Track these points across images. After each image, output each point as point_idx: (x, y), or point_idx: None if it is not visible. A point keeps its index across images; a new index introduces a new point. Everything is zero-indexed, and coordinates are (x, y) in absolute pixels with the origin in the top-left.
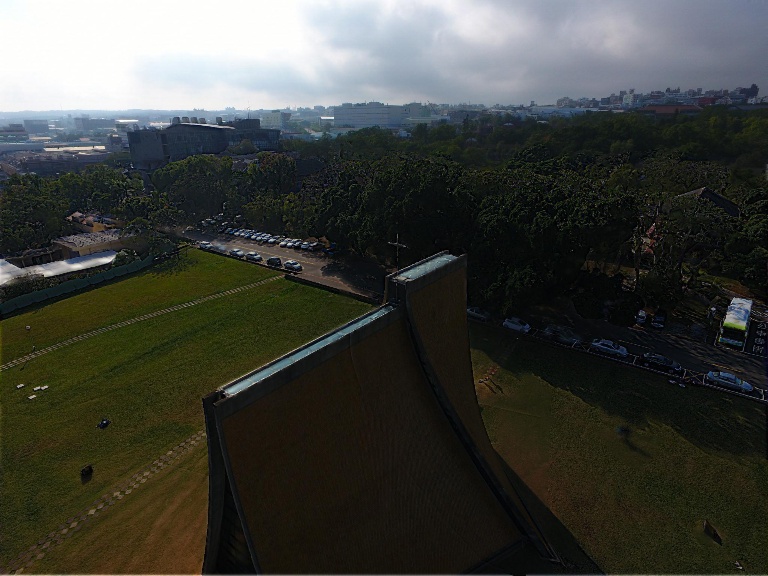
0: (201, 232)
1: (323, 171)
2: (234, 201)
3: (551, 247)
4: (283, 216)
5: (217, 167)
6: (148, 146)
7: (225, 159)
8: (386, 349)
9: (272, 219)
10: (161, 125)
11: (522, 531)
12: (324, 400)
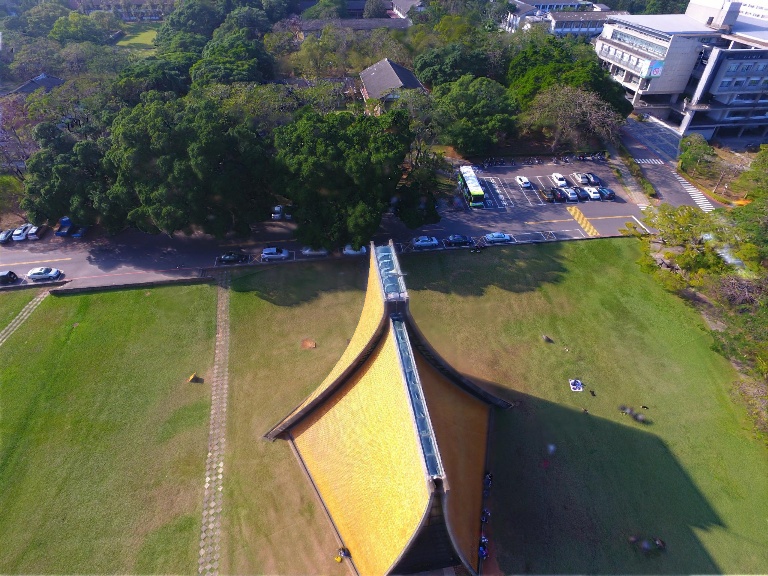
0: None
1: None
2: None
3: (371, 179)
4: None
5: None
6: None
7: None
8: None
9: None
10: None
11: (489, 403)
12: None
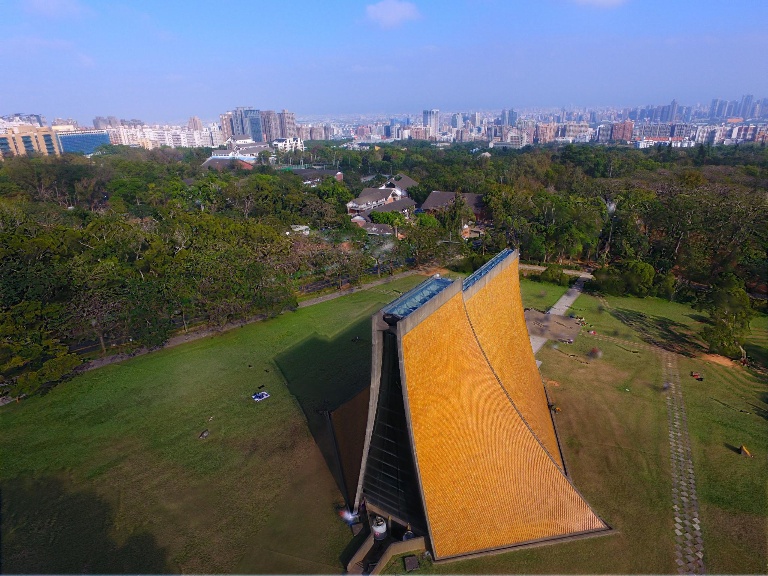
0: None
1: None
2: None
3: None
4: None
5: None
6: None
7: None
8: None
9: None
10: None
11: None
12: None
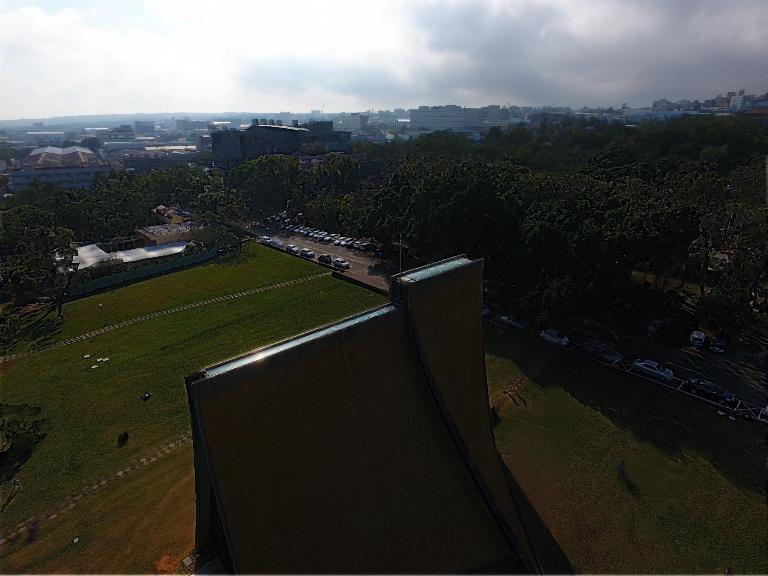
0: (265, 228)
1: (380, 172)
2: (297, 199)
3: (594, 257)
4: (339, 215)
5: (285, 167)
6: (228, 146)
7: (292, 159)
8: (383, 348)
9: (330, 218)
10: (241, 127)
11: (513, 549)
12: (310, 391)
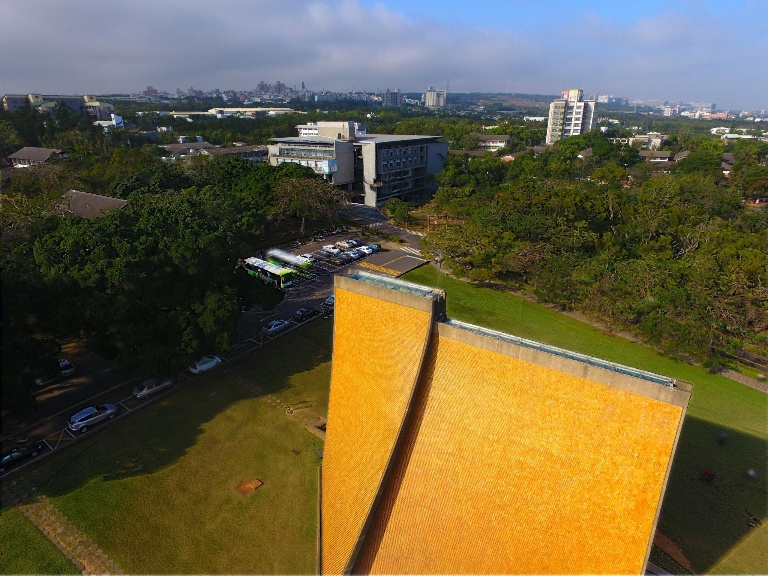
0: None
1: None
2: None
3: (208, 265)
4: None
5: None
6: None
7: None
8: None
9: None
10: None
11: None
12: None
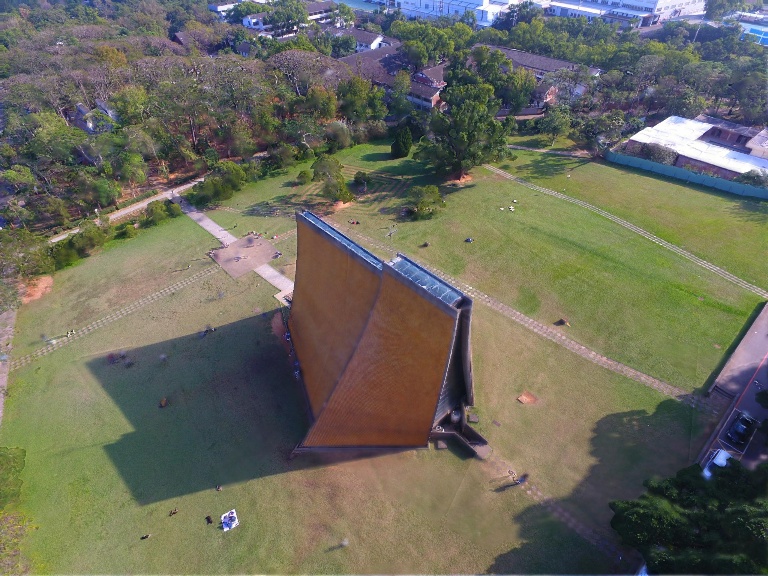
0: None
1: None
2: None
3: None
4: None
5: None
6: None
7: None
8: (368, 283)
9: None
10: None
11: None
12: (330, 261)
